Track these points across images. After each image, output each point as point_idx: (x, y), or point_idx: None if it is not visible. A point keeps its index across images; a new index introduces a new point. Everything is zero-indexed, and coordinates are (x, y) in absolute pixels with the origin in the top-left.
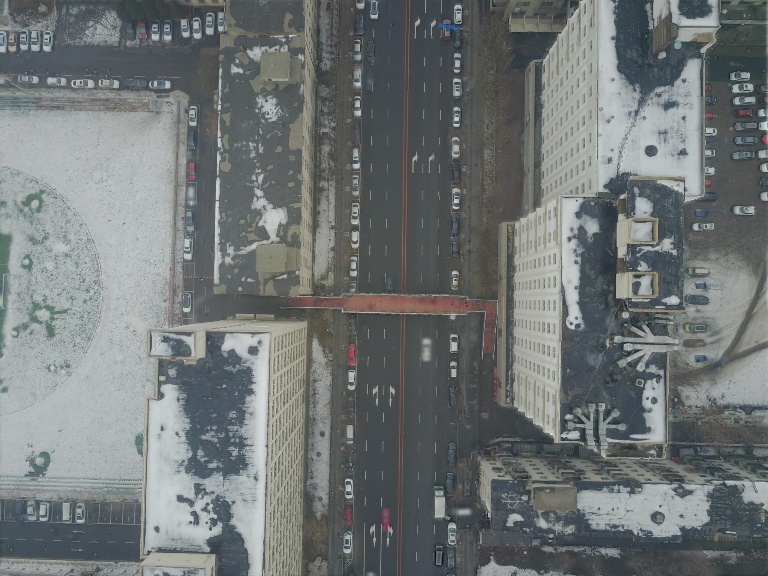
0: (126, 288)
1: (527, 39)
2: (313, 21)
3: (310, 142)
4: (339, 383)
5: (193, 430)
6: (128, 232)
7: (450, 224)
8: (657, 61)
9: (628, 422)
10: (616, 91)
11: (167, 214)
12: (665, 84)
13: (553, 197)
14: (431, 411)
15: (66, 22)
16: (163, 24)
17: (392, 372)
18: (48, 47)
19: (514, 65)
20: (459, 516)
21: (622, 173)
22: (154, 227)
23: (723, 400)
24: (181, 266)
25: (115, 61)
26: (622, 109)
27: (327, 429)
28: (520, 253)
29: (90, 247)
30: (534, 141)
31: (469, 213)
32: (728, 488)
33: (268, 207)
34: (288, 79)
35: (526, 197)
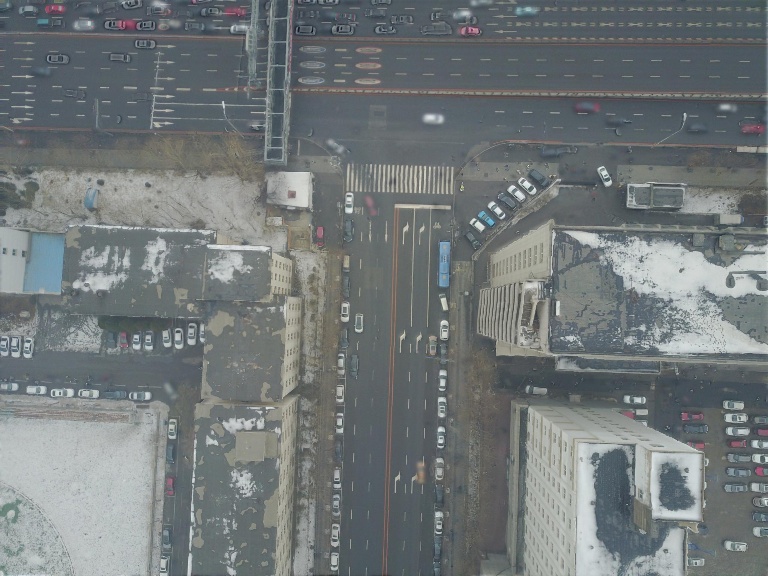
0: None
1: (514, 358)
2: (295, 345)
3: (289, 476)
4: None
5: None
6: (104, 547)
7: (432, 549)
8: (638, 531)
9: None
10: (595, 560)
11: (144, 529)
12: (646, 554)
13: None
14: None
15: (47, 327)
16: (145, 333)
17: None
18: (28, 354)
19: (501, 384)
20: None
21: None
22: (130, 542)
23: None
24: None
25: (95, 368)
26: None
27: None
28: None
29: (65, 561)
30: (518, 490)
31: (452, 537)
32: None
33: None
34: (264, 455)
35: (509, 539)
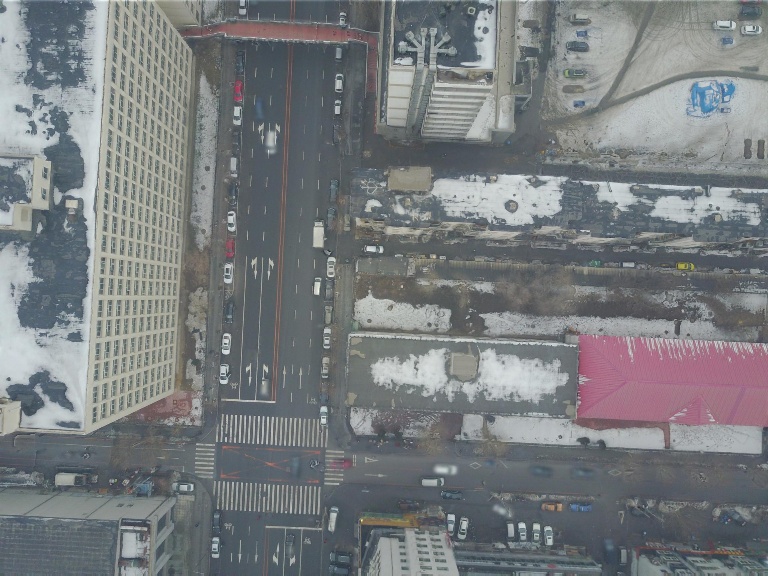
0: None
1: None
2: None
3: None
4: (226, 119)
5: (34, 43)
6: None
7: None
8: None
9: (460, 50)
10: None
11: None
12: None
13: None
14: (315, 149)
15: None
16: None
17: (278, 110)
18: None
19: None
20: (339, 251)
21: None
22: None
23: (599, 144)
24: None
25: None
26: None
27: (212, 163)
28: None
29: None
30: None
31: None
32: (584, 187)
33: None
34: None
35: None
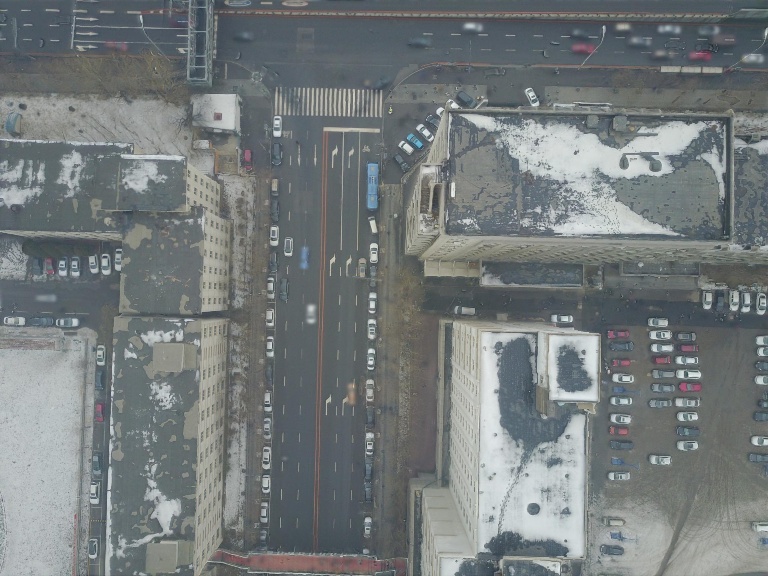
0: (31, 532)
1: (444, 280)
2: (222, 267)
3: (217, 397)
4: None
5: None
6: (33, 474)
7: (363, 470)
8: (540, 417)
9: None
10: (498, 447)
11: (74, 456)
12: (548, 440)
13: (455, 484)
14: None
15: None
16: (71, 260)
17: None
18: None
19: (430, 305)
20: None
21: (503, 532)
22: (60, 469)
23: None
24: (88, 510)
25: (21, 296)
26: (504, 465)
27: None
28: (423, 534)
29: None
30: (443, 405)
31: (383, 457)
32: None
33: (161, 499)
34: (182, 367)
35: (437, 455)
